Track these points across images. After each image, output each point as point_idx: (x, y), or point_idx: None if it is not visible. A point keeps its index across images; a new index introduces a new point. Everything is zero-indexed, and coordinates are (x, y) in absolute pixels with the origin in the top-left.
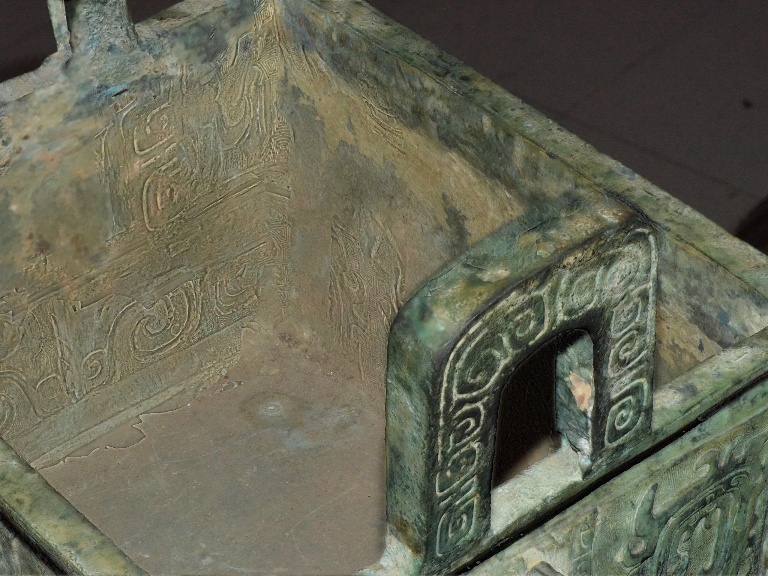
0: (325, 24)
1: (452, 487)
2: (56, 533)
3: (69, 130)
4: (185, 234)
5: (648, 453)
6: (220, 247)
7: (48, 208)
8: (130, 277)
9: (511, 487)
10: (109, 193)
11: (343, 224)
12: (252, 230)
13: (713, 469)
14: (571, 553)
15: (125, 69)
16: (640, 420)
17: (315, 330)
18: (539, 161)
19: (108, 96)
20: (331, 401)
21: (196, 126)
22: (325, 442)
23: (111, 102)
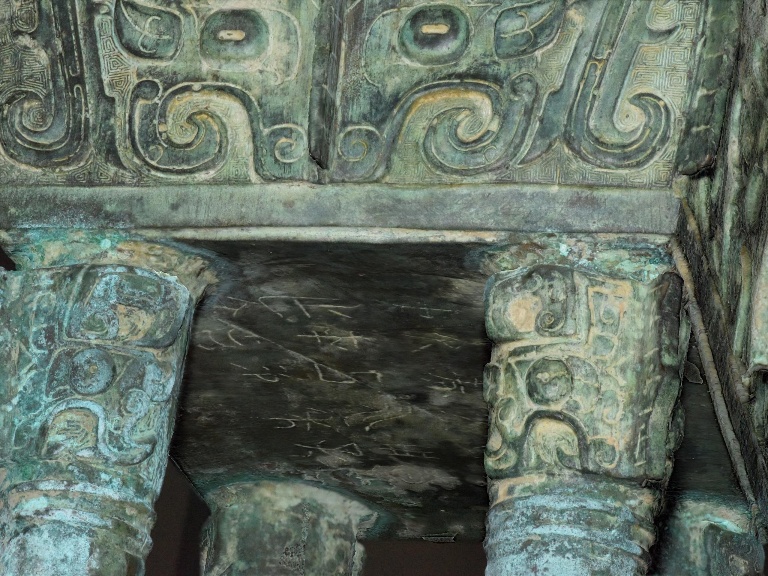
0: None
1: None
2: None
3: None
4: None
5: None
6: None
7: None
8: None
9: None
10: None
11: None
12: None
13: None
14: None
15: None
16: None
17: None
18: None
19: None
20: None
21: None
22: None
23: None
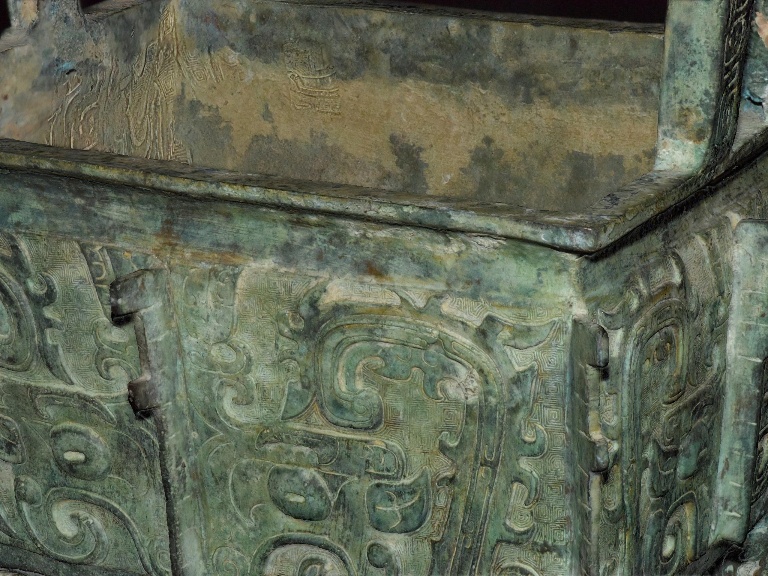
0: (240, 10)
1: (730, 62)
2: (340, 193)
3: (34, 102)
4: None
5: None
6: None
7: None
8: None
9: None
10: None
11: None
12: None
13: None
14: None
15: (75, 46)
16: None
17: None
18: (523, 36)
19: (63, 72)
20: None
21: (112, 139)
22: None
23: (64, 80)
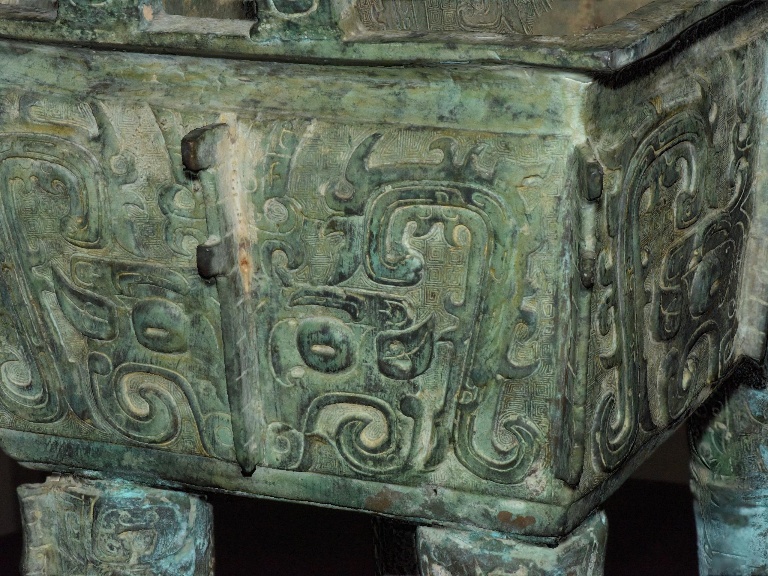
0: None
1: None
2: None
3: None
4: None
5: (334, 62)
6: None
7: None
8: None
9: (211, 21)
10: None
11: None
12: None
13: (447, 160)
14: (265, 142)
15: None
16: (317, 7)
17: None
18: None
19: None
20: None
21: None
22: None
23: None
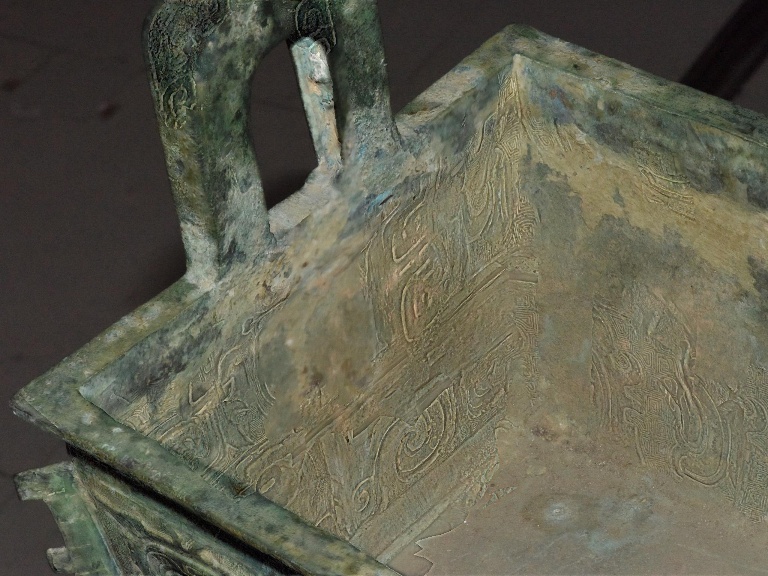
0: (587, 93)
1: None
2: None
3: (341, 249)
4: (440, 339)
5: None
6: (472, 347)
7: (319, 336)
8: (394, 395)
9: None
10: (372, 309)
11: (608, 303)
12: (499, 323)
13: None
14: None
15: (390, 174)
16: None
17: (574, 419)
18: None
19: (375, 206)
20: (616, 493)
21: (444, 222)
22: (631, 539)
23: (378, 211)
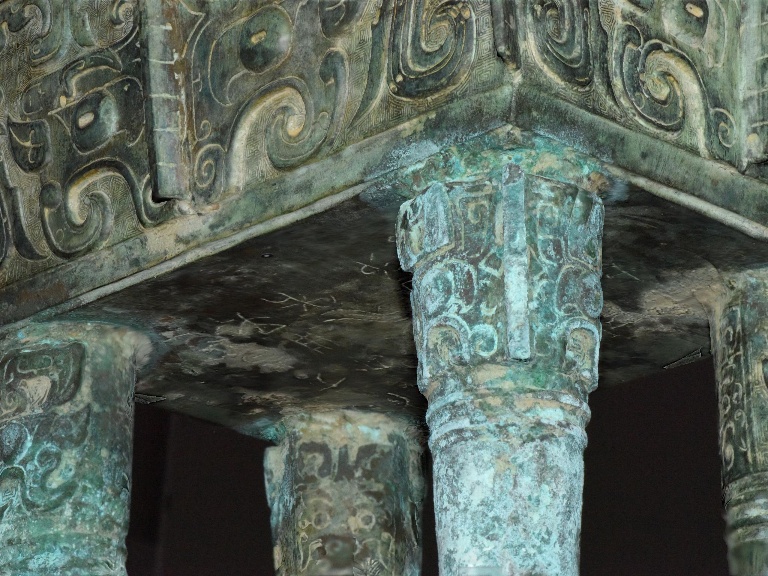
0: None
1: None
2: None
3: None
4: None
5: None
6: None
7: None
8: None
9: None
10: None
11: None
12: None
13: None
14: None
15: None
16: None
17: None
18: None
19: None
20: None
21: None
22: None
23: None
